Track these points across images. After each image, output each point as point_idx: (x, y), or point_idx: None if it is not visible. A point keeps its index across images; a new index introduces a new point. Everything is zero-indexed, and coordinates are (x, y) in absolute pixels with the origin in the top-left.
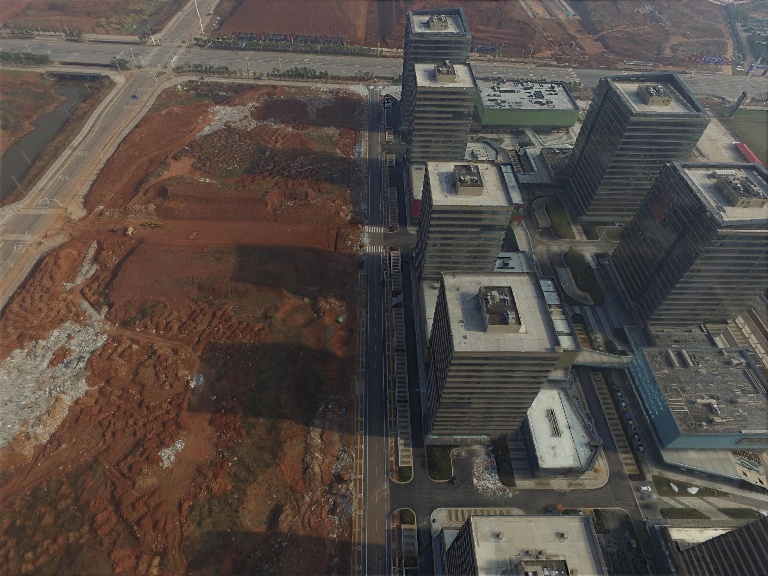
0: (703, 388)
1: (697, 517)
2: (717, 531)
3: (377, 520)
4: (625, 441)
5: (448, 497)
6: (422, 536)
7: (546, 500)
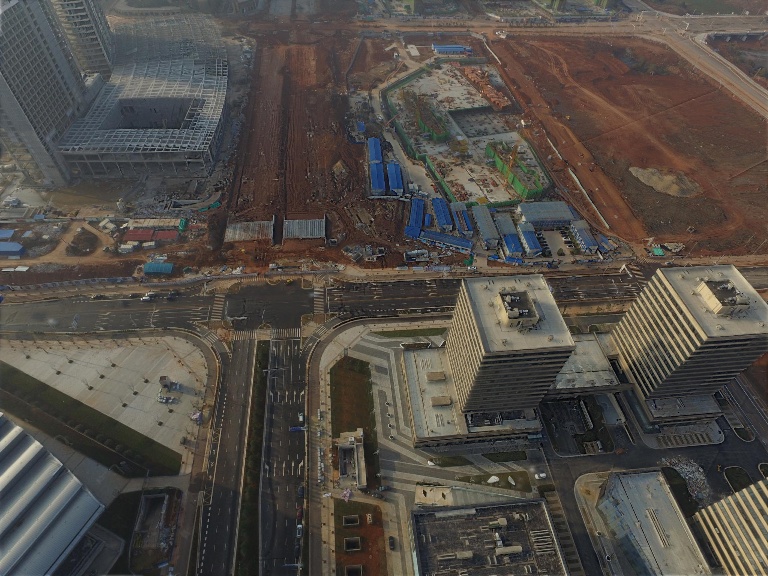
0: (507, 575)
1: (494, 455)
2: (498, 429)
3: (764, 431)
4: (559, 531)
5: (718, 453)
6: (723, 420)
7: (631, 458)
